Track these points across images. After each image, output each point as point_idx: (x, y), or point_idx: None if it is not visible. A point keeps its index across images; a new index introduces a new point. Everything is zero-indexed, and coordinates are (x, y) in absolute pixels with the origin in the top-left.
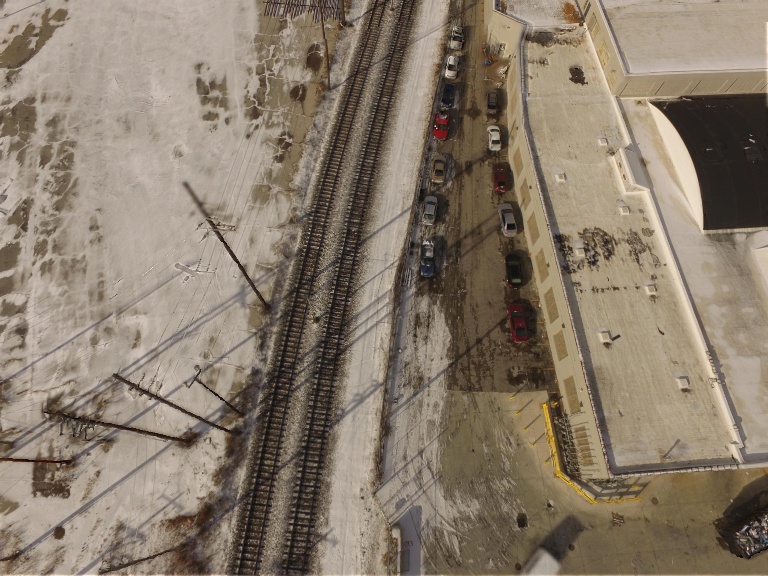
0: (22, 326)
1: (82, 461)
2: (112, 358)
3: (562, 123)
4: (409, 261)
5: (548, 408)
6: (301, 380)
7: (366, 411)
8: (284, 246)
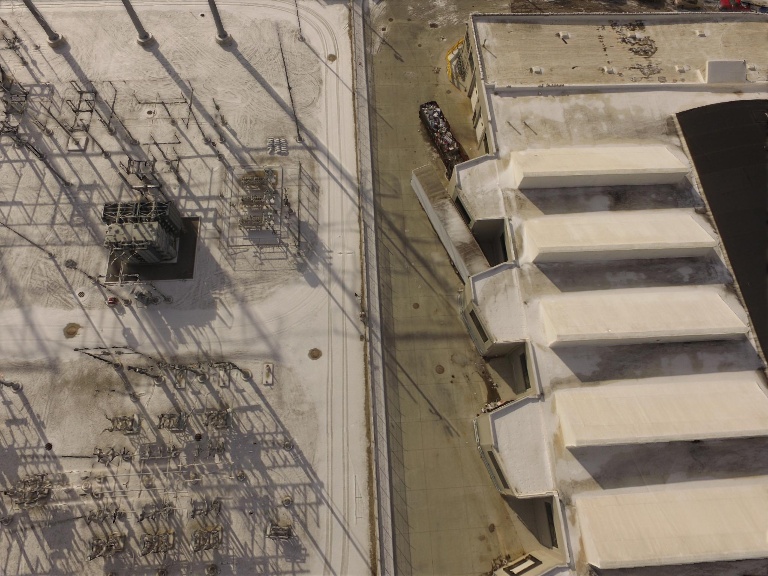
0: None
1: None
2: None
3: (762, 43)
4: None
5: None
6: None
7: None
8: None
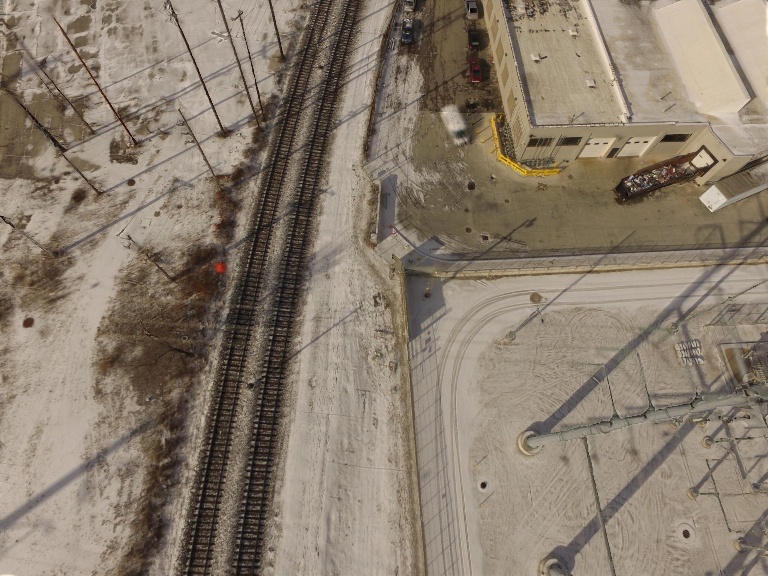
0: (96, 65)
1: (146, 144)
2: (165, 86)
3: None
4: (393, 34)
5: (495, 122)
6: (309, 103)
7: (358, 122)
8: (296, 22)
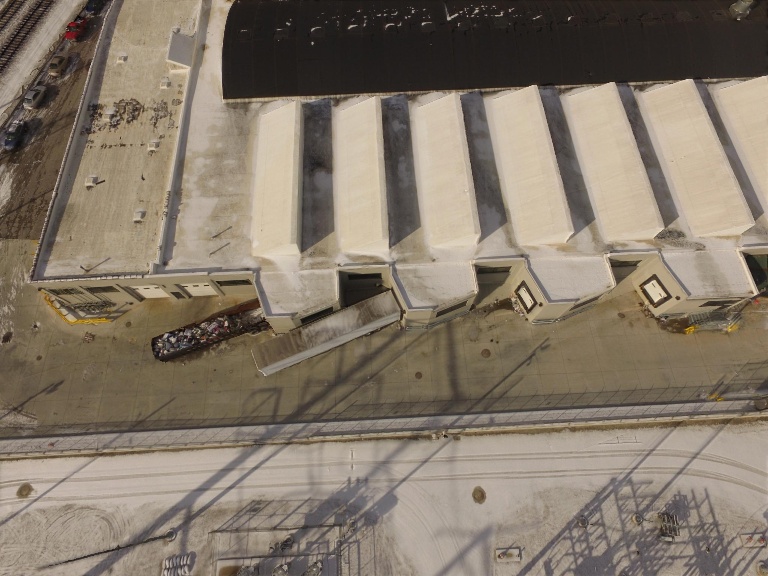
0: None
1: None
2: None
3: (146, 16)
4: (1, 138)
5: None
6: None
7: None
8: None
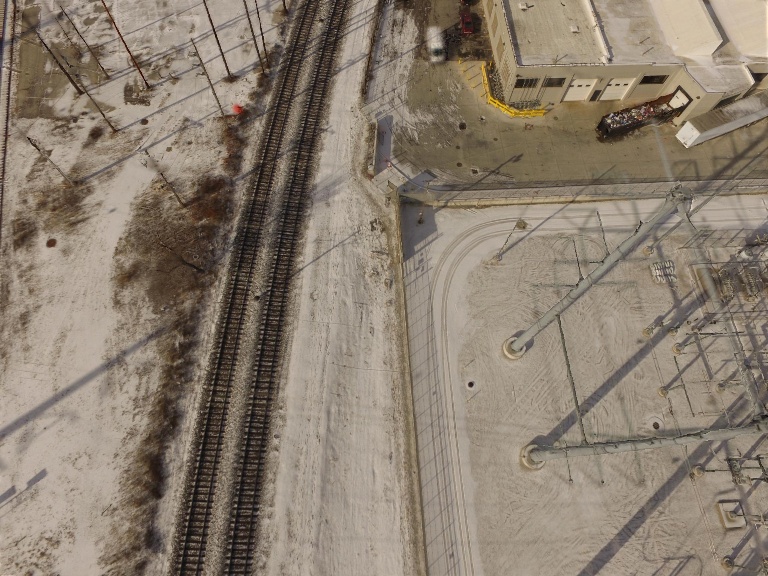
0: None
1: (157, 88)
2: (175, 37)
3: None
4: None
5: (485, 69)
6: (310, 52)
7: (356, 69)
8: None
